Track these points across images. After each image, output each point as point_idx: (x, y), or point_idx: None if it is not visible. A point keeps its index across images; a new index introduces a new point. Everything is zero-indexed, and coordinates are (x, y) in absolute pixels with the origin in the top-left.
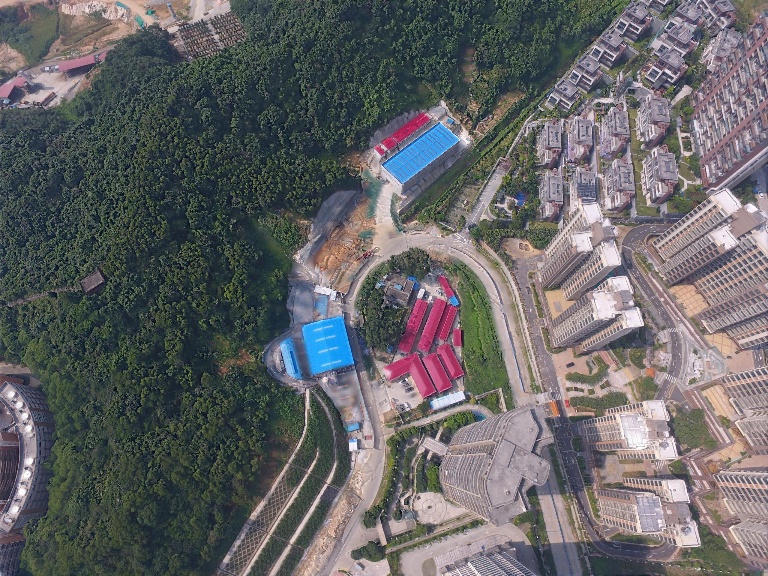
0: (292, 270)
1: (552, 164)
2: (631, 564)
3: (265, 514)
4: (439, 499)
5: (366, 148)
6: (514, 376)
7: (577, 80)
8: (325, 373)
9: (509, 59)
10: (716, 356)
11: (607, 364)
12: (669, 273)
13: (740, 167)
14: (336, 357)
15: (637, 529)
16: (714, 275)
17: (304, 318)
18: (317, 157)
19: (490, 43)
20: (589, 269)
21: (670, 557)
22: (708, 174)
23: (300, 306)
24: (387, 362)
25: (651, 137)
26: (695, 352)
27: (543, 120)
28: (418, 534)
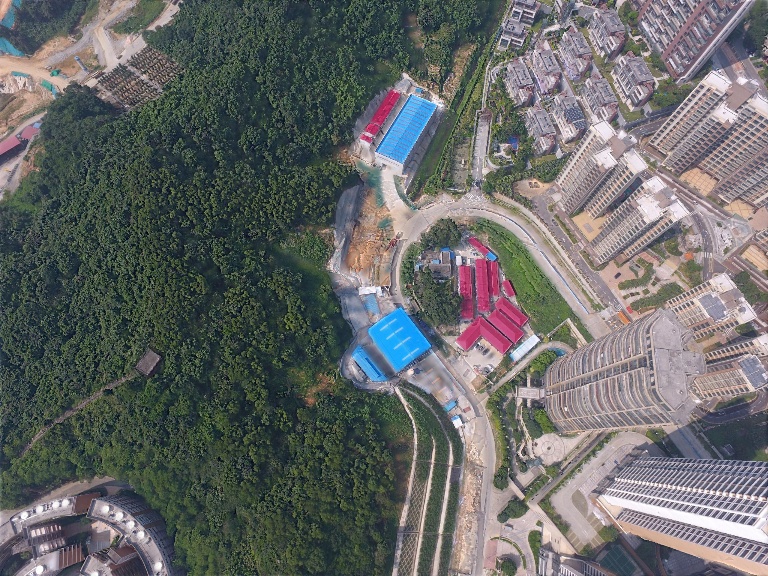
0: (332, 281)
1: (529, 101)
2: (740, 423)
3: (411, 516)
4: (554, 438)
5: (352, 141)
6: (574, 303)
7: (519, 17)
8: (407, 366)
9: (452, 15)
10: (739, 222)
11: (650, 263)
12: (676, 164)
13: (704, 50)
14: (412, 347)
15: (749, 389)
16: (717, 152)
17: (362, 323)
18: (307, 165)
19: (429, 4)
20: (616, 182)
21: (767, 404)
22: (674, 66)
23: (354, 313)
24: (455, 334)
25: (613, 48)
26: (719, 225)
27: (503, 63)
28: (552, 475)
